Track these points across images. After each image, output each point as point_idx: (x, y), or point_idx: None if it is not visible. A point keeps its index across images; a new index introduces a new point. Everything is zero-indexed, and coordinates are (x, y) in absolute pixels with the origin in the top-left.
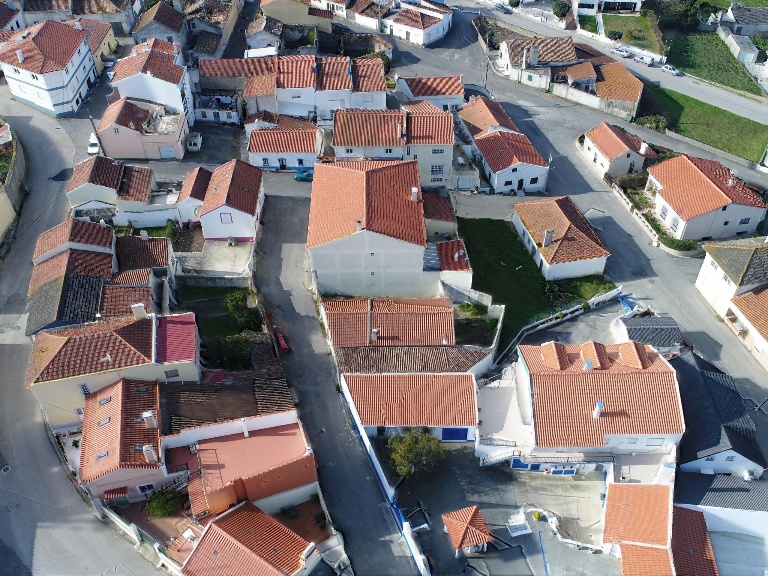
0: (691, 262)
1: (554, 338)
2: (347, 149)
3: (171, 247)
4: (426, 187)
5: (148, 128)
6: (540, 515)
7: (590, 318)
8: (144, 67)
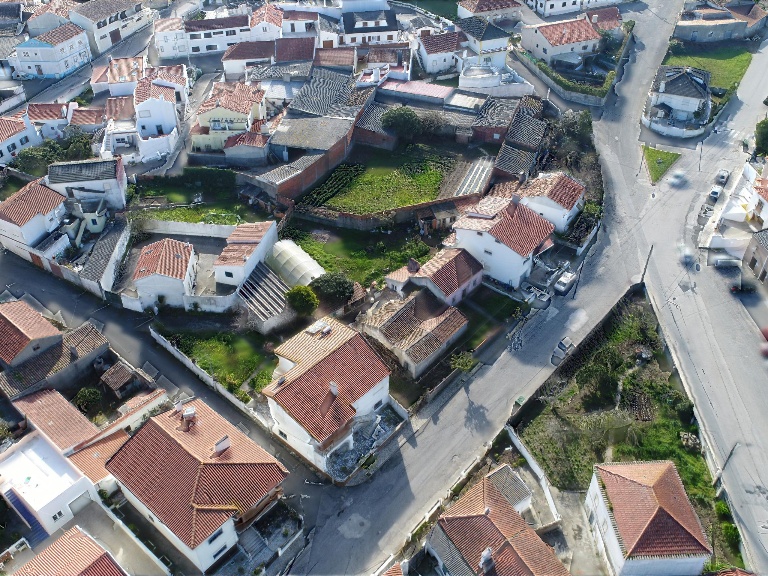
0: None
1: None
2: None
3: None
4: None
5: None
6: (312, 4)
7: (432, 20)
8: None
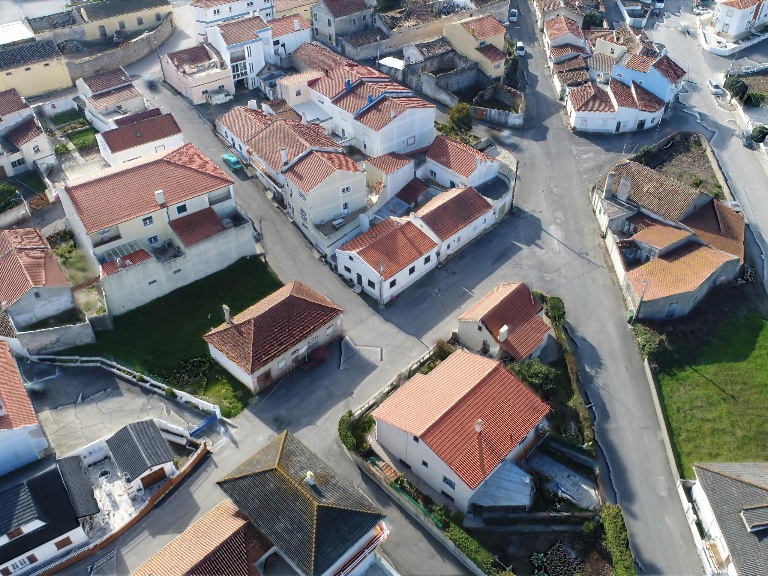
0: (342, 463)
1: (106, 386)
2: None
3: (44, 139)
4: (240, 213)
5: (190, 69)
6: None
7: (158, 403)
8: (227, 24)
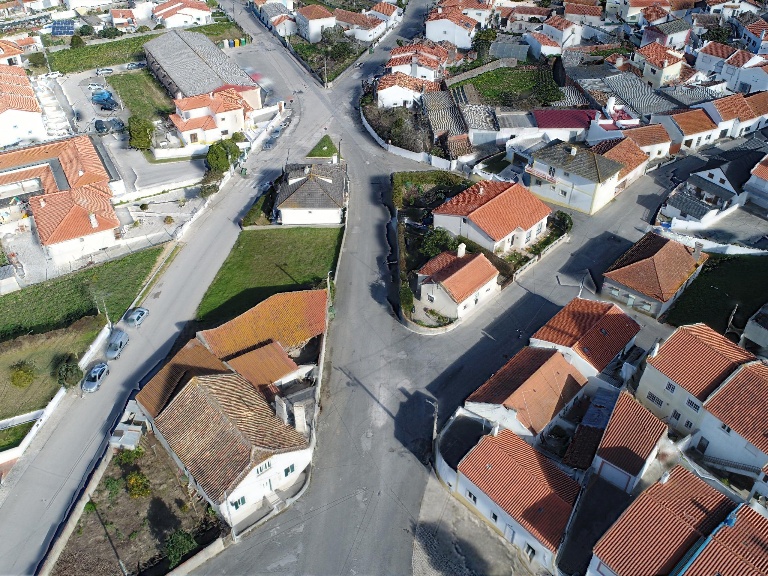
0: None
1: (758, 245)
2: None
3: None
4: None
5: None
6: None
7: (710, 239)
8: None
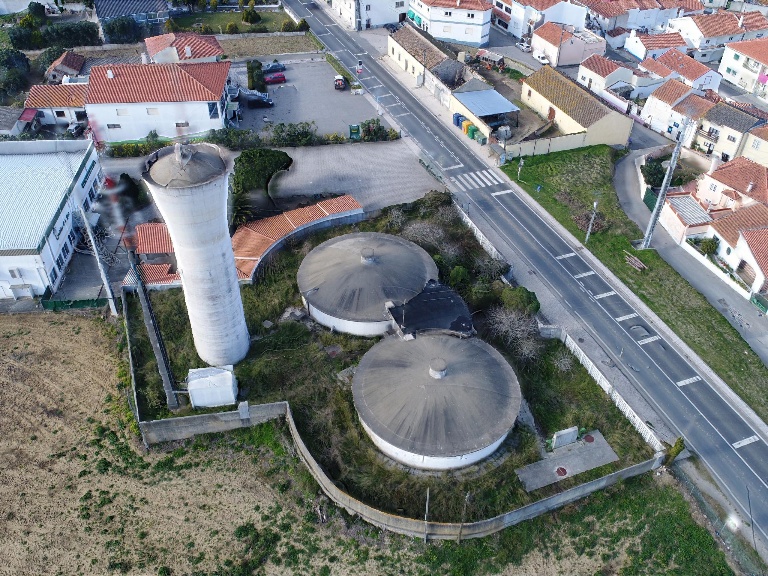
0: None
1: None
2: (707, 40)
3: None
4: None
5: None
6: None
7: None
8: None
